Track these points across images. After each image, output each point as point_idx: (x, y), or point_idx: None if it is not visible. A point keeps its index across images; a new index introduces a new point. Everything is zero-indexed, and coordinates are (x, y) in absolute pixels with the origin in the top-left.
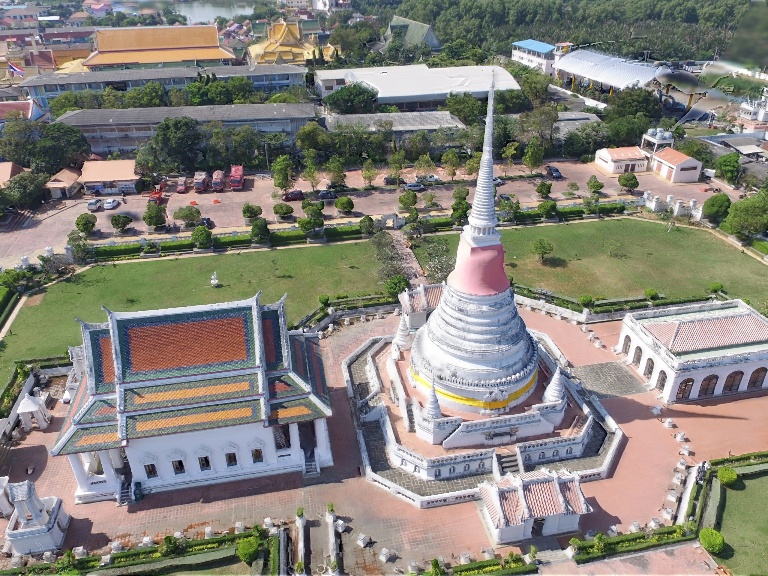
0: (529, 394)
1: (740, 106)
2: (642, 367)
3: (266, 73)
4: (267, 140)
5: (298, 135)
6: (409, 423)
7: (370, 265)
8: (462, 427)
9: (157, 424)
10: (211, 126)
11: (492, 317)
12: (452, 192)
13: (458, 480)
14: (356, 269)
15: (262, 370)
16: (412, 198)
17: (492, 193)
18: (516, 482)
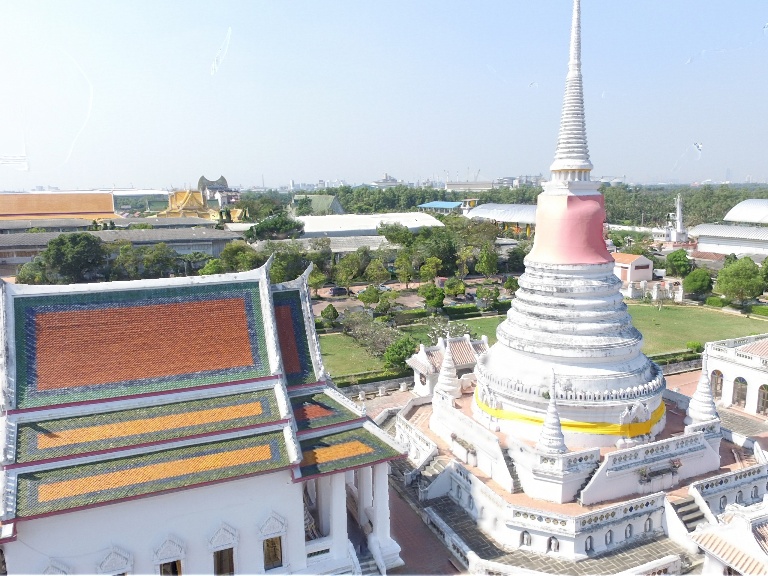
0: (665, 420)
1: (652, 231)
2: (752, 403)
3: (172, 223)
4: (187, 258)
5: (223, 254)
6: (511, 478)
7: (347, 351)
8: (608, 461)
9: (84, 485)
10: (117, 244)
11: (605, 297)
12: (411, 297)
13: (624, 554)
14: (330, 356)
15: (281, 382)
16: (375, 293)
17: None
18: (763, 508)
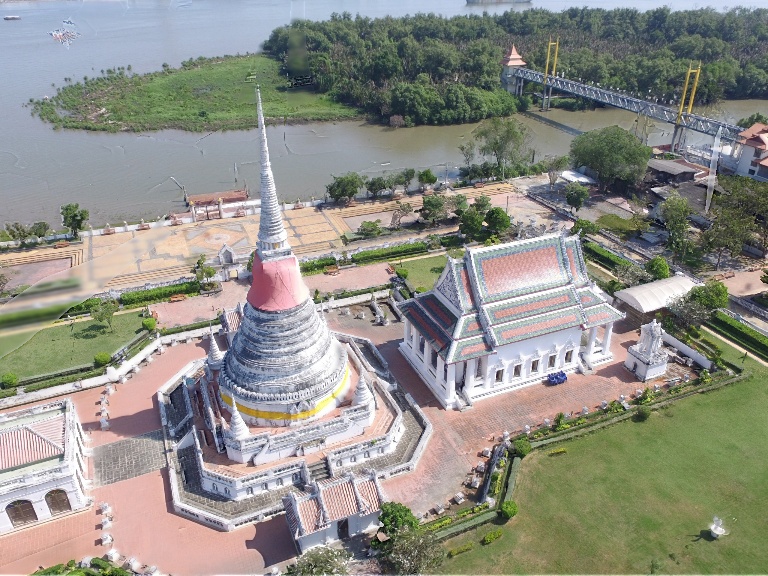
0: None
1: None
2: None
3: None
4: None
5: None
6: None
7: None
8: None
9: None
10: None
11: None
12: None
13: None
14: None
15: None
16: None
17: None
18: None
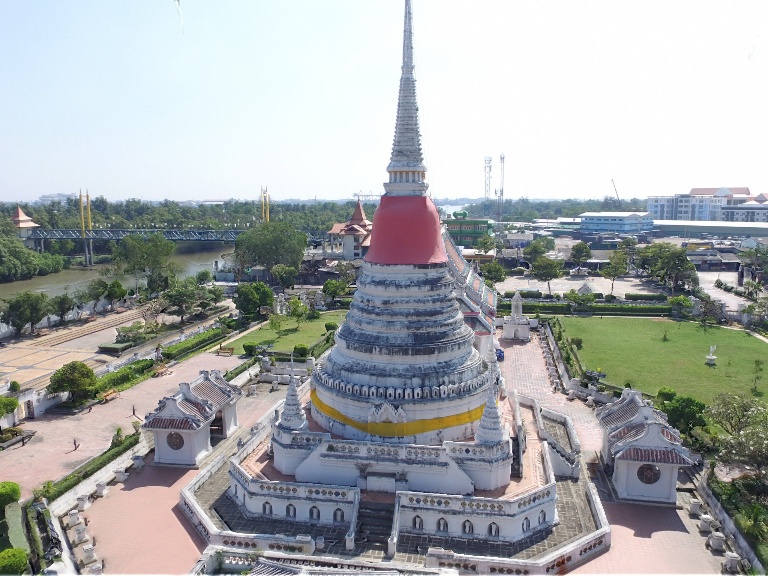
0: None
1: None
2: None
3: None
4: None
5: None
6: None
7: None
8: None
9: None
10: None
11: None
12: None
13: None
14: None
15: None
16: None
17: (398, 127)
18: None
